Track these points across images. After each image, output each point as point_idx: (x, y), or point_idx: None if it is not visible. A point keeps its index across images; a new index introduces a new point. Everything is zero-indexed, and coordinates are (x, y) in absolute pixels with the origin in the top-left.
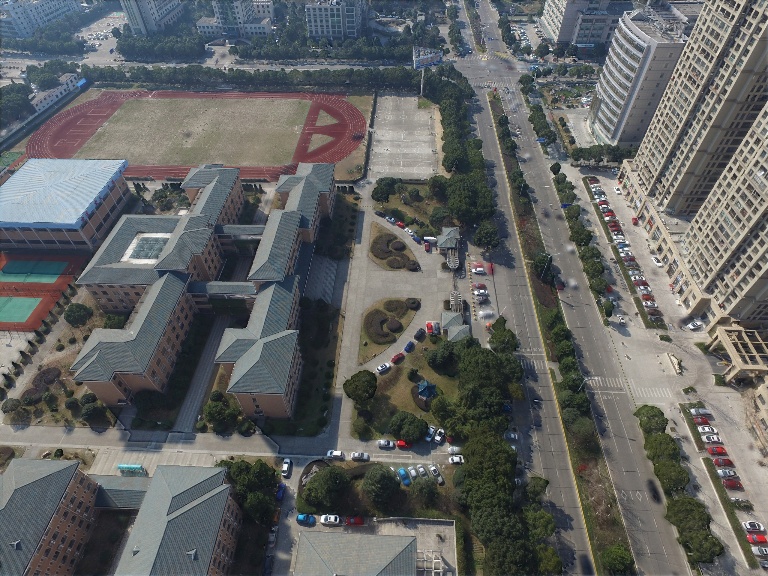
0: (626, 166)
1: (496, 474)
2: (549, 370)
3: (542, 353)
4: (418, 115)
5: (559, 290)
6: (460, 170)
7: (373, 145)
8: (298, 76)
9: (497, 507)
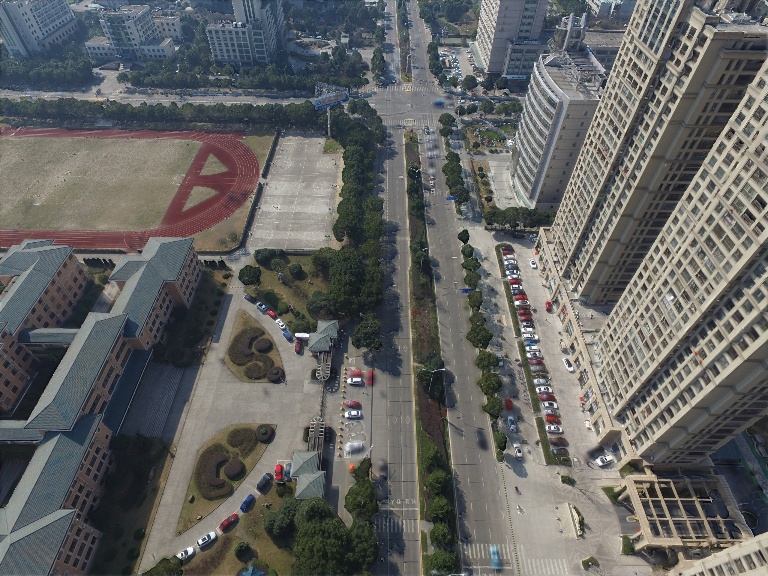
0: (542, 236)
1: None
2: (420, 535)
3: (415, 507)
4: (321, 161)
5: (449, 407)
6: (353, 239)
7: (261, 202)
8: (188, 112)
9: None
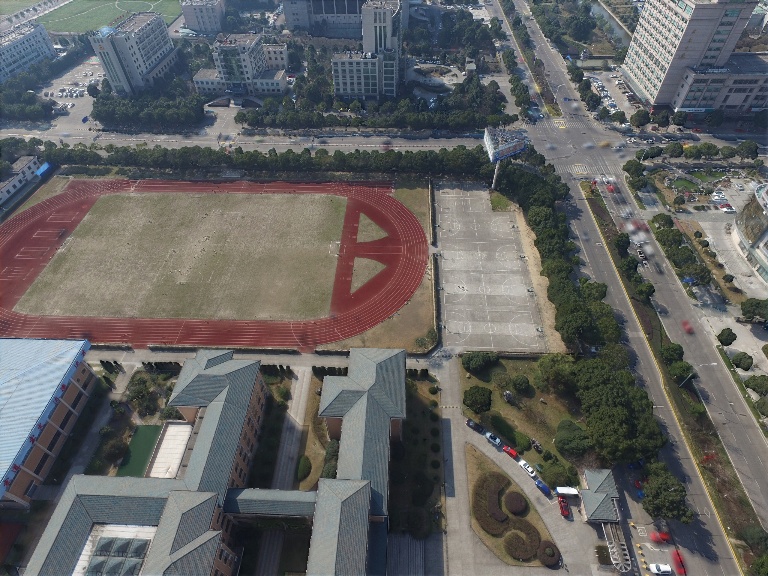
0: None
1: None
2: None
3: None
4: (495, 223)
5: None
6: (583, 339)
7: (442, 280)
8: (328, 162)
9: None
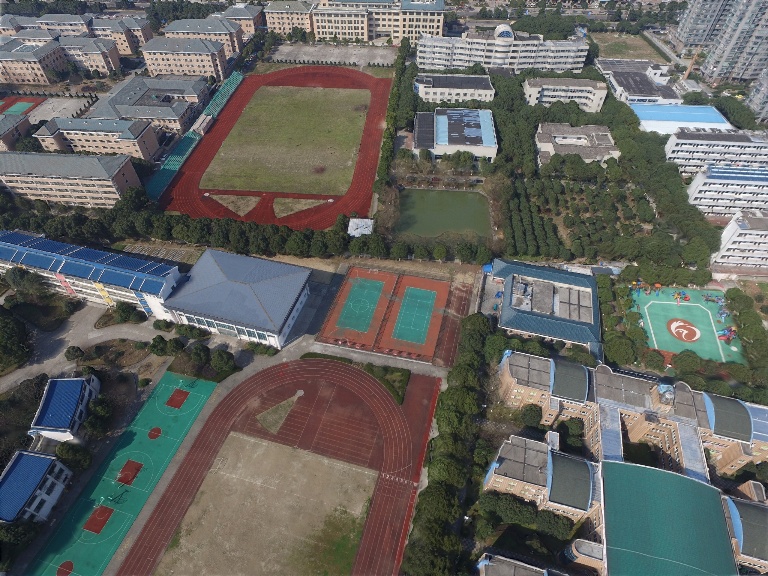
0: None
1: (201, 5)
2: None
3: None
4: None
5: None
6: (41, 10)
7: None
8: None
9: (209, 5)
